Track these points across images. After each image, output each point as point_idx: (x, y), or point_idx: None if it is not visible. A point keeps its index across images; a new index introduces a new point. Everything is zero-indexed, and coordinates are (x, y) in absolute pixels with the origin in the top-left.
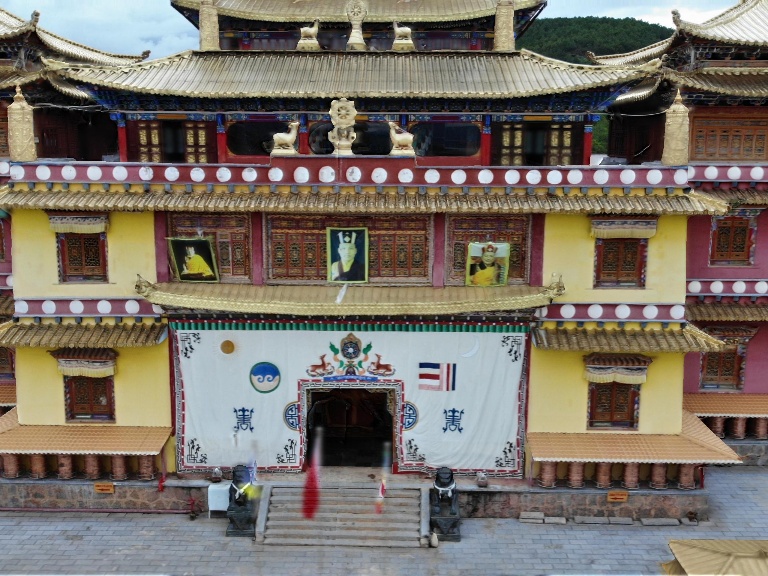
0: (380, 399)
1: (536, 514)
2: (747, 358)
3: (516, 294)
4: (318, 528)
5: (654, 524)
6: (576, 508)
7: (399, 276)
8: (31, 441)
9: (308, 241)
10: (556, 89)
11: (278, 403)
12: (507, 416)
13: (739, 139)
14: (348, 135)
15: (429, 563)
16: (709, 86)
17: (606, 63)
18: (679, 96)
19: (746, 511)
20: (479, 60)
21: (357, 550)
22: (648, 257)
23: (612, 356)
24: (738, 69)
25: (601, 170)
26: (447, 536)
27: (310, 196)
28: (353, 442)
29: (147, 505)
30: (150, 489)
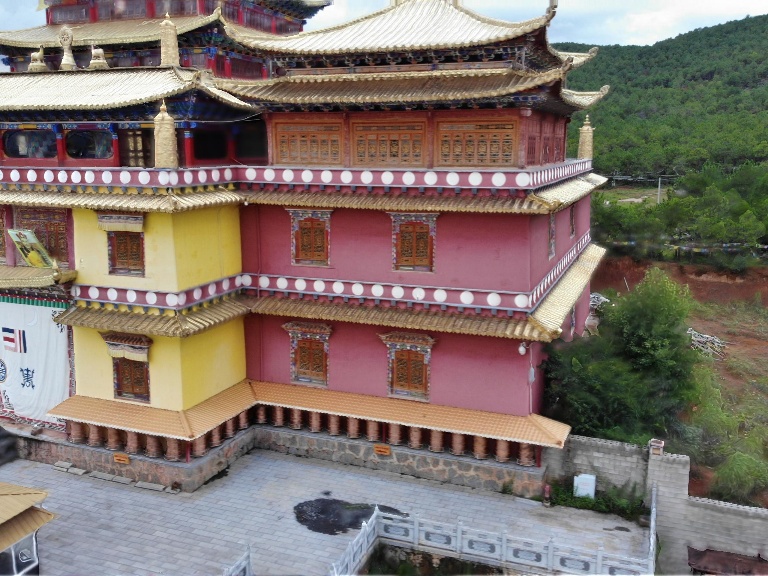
0: None
1: (65, 464)
2: (330, 356)
3: None
4: None
5: (142, 487)
6: (95, 464)
7: None
8: None
9: None
10: (138, 100)
11: None
12: (60, 379)
13: (317, 144)
14: None
15: None
16: (261, 94)
17: None
18: (163, 106)
19: (239, 492)
20: (135, 75)
21: None
22: (145, 249)
23: (124, 335)
24: (320, 76)
25: (106, 171)
26: None
27: None
28: None
29: None
30: None
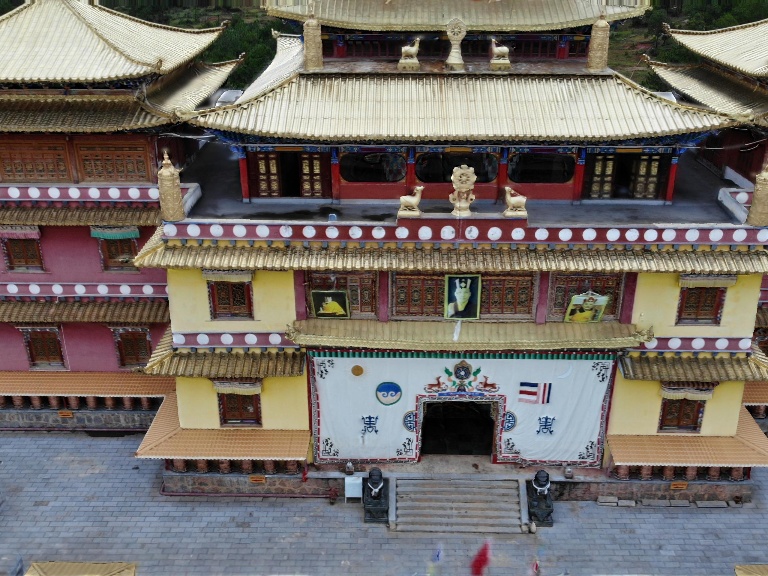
0: (484, 407)
1: (611, 498)
2: None
3: (609, 333)
4: (438, 516)
5: (707, 507)
6: (644, 493)
7: (506, 313)
8: (197, 447)
9: (428, 285)
10: (652, 133)
11: (399, 412)
12: (591, 422)
13: None
14: (467, 197)
15: (532, 550)
16: None
17: (683, 42)
18: None
19: None
20: (575, 85)
21: (472, 536)
22: (726, 301)
23: None
24: None
25: (693, 229)
26: (542, 523)
27: (434, 253)
28: (452, 425)
29: (293, 491)
30: (295, 480)
